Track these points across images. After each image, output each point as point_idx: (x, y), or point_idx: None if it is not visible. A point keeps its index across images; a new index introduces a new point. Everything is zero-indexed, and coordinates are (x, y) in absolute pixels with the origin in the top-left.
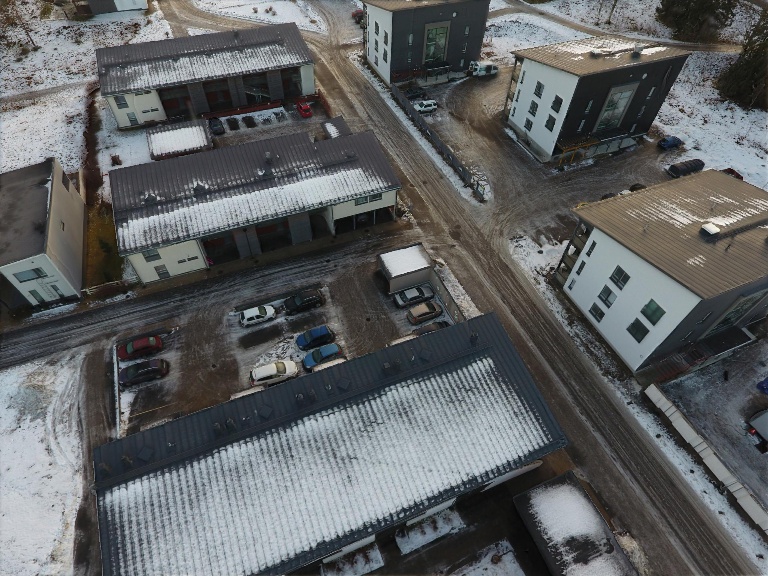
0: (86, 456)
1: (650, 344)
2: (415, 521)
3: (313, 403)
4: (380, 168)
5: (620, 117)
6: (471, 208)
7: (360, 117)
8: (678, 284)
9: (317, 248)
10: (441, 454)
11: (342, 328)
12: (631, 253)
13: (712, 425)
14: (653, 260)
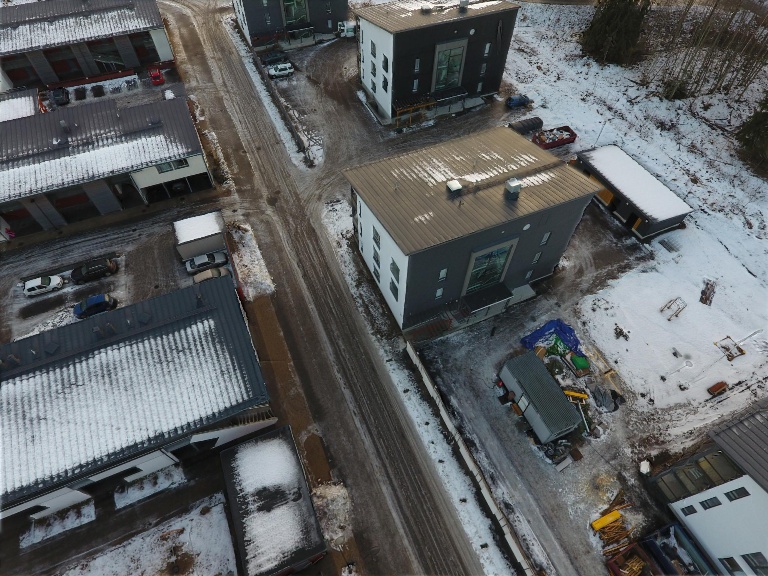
0: None
1: (401, 302)
2: (137, 478)
3: (15, 368)
4: (183, 134)
5: (458, 76)
6: (297, 173)
7: (214, 83)
8: (392, 241)
9: (126, 218)
10: (134, 413)
11: (127, 296)
12: (370, 212)
13: (463, 379)
14: (383, 218)
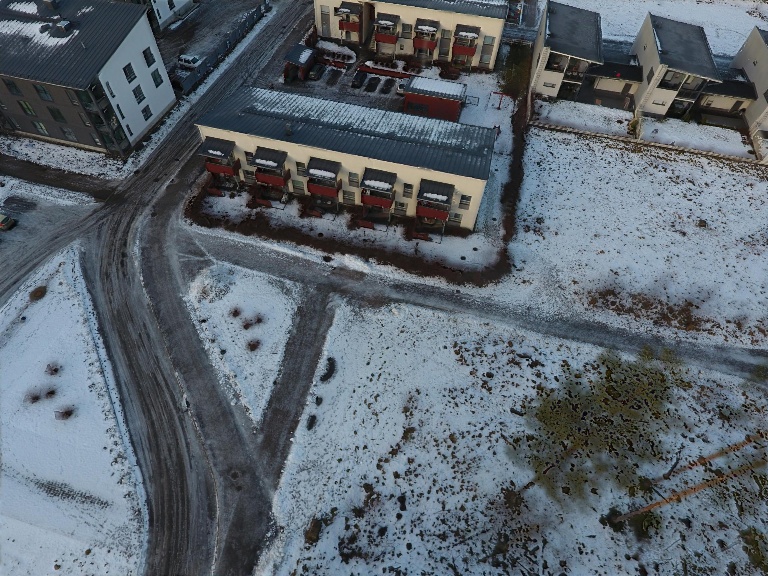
0: (537, 3)
1: None
2: None
3: None
4: None
5: None
6: (282, 7)
7: None
8: None
9: None
10: None
11: None
12: None
13: None
14: None
